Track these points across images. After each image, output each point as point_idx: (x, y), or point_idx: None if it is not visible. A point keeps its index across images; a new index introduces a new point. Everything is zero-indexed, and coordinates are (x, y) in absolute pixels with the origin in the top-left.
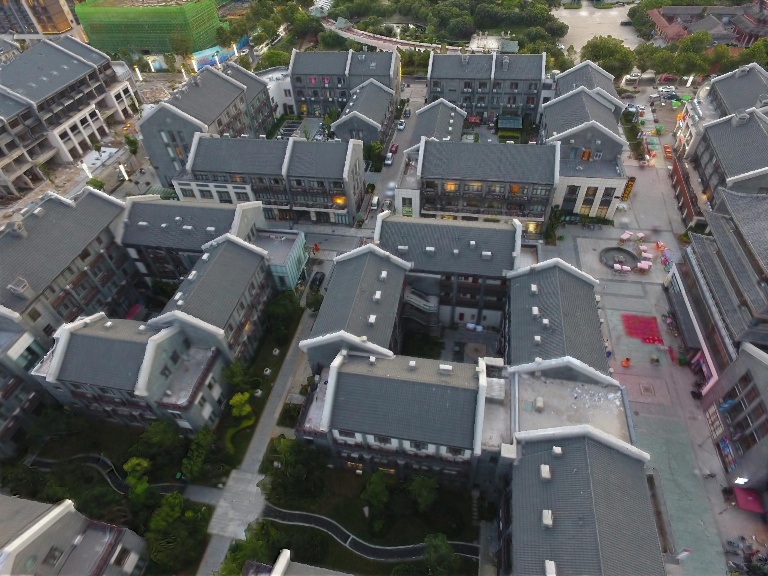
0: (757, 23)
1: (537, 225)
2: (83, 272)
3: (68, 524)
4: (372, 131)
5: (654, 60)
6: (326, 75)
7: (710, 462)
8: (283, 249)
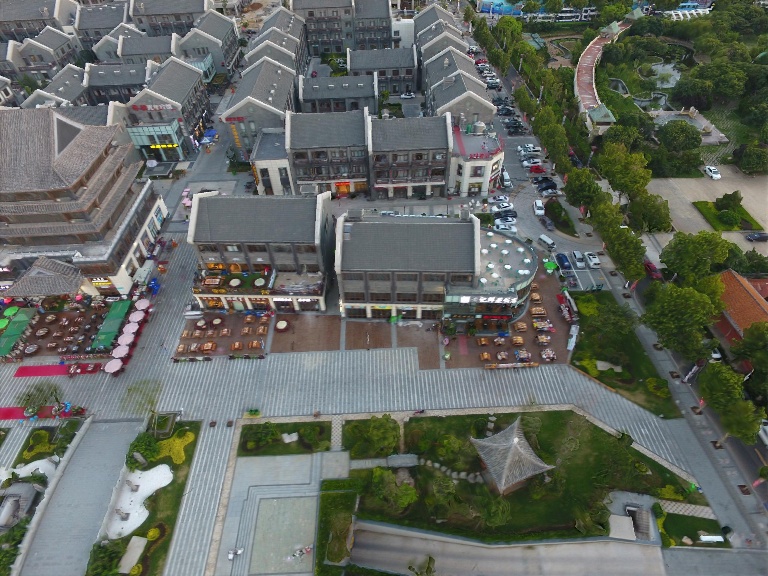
0: None
1: None
2: (170, 23)
3: (48, 55)
4: None
5: None
6: None
7: None
8: None
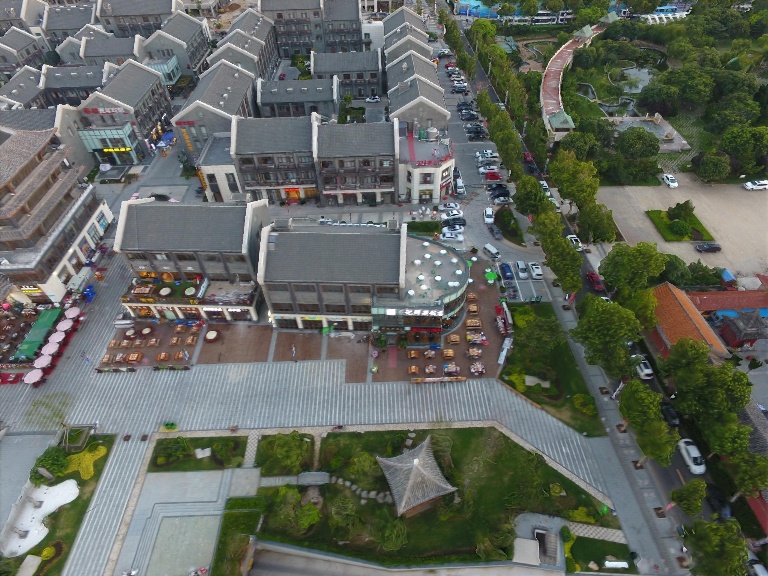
0: None
1: None
2: (138, 24)
3: (12, 56)
4: None
5: None
6: None
7: None
8: None
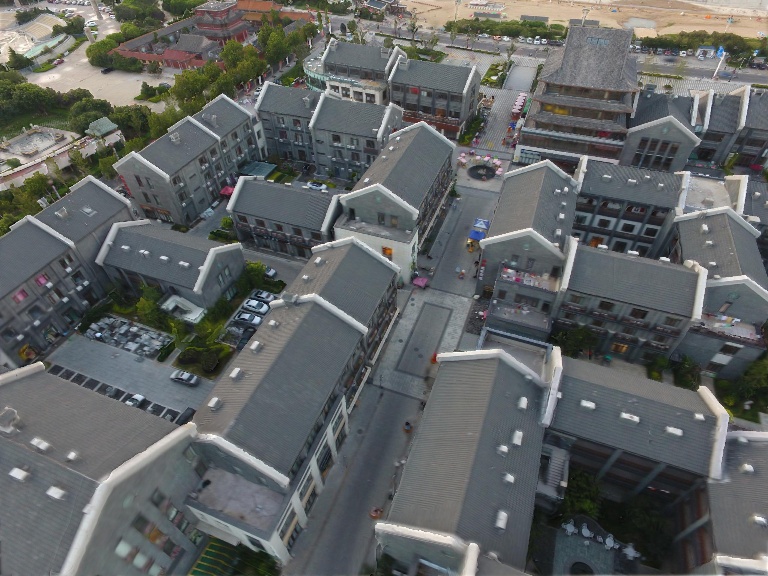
0: (220, 28)
1: None
2: None
3: None
4: (236, 256)
5: (238, 73)
6: (39, 271)
7: None
8: None
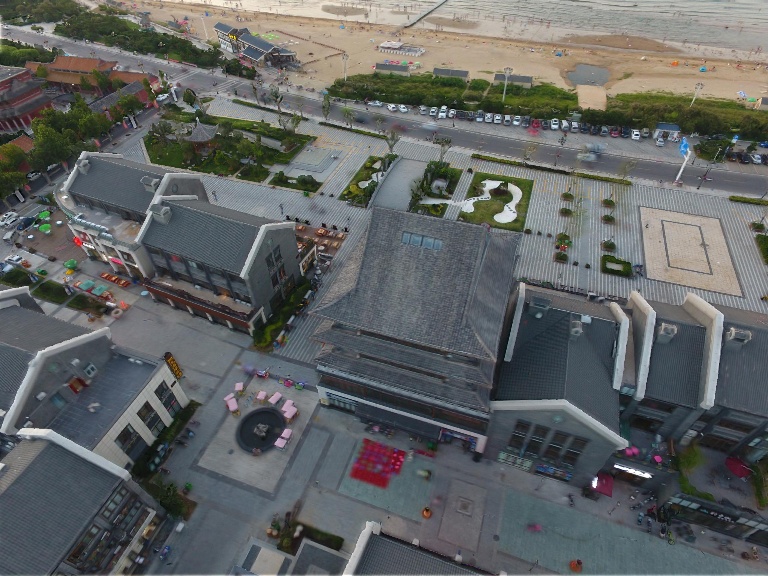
0: None
1: None
2: None
3: None
4: None
5: None
6: None
7: (554, 490)
8: None
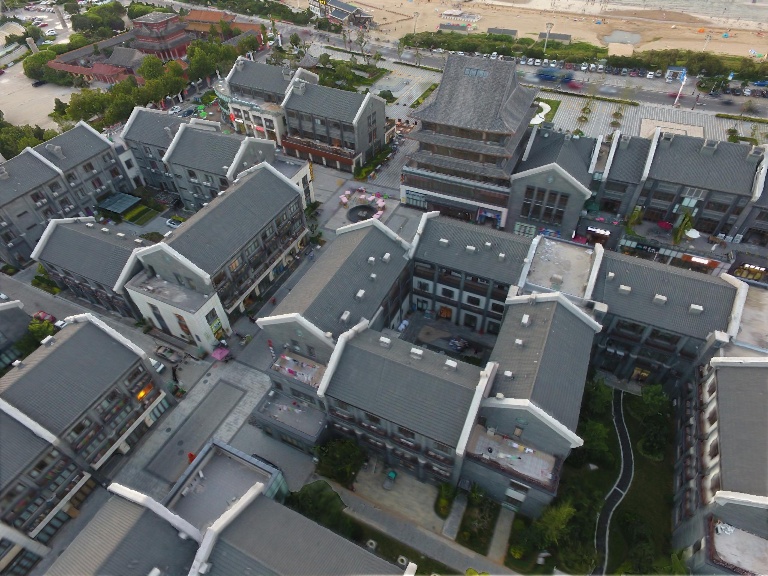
0: (158, 41)
1: (302, 239)
2: None
3: None
4: (12, 316)
5: (146, 92)
6: None
7: None
8: (223, 479)
